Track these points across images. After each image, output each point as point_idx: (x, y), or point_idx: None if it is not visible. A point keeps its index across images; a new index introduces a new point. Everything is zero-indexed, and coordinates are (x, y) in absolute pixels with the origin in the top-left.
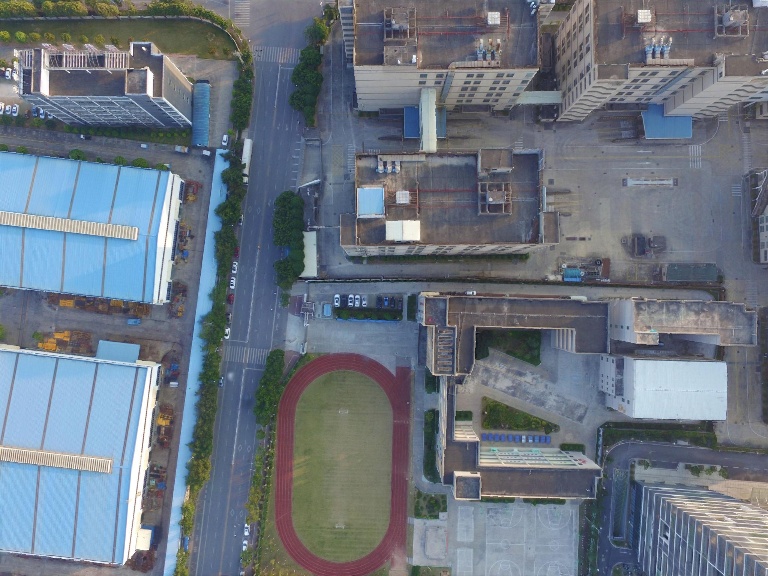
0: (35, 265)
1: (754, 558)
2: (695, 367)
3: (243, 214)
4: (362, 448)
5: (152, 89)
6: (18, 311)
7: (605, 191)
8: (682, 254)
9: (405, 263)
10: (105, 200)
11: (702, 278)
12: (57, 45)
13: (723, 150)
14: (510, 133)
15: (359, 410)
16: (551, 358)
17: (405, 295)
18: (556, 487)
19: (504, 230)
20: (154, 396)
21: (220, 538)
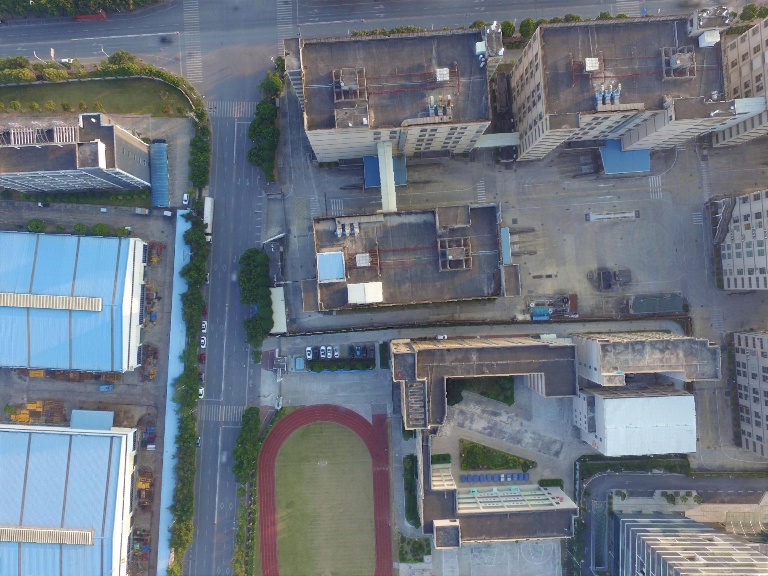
0: None
1: None
2: (663, 402)
3: (209, 272)
4: (343, 497)
5: (105, 160)
6: None
7: (569, 227)
8: (647, 285)
9: (375, 311)
10: (66, 272)
11: (668, 309)
12: (7, 112)
13: (682, 179)
14: (471, 175)
15: (338, 460)
16: (525, 396)
17: (377, 343)
18: (534, 528)
19: (466, 284)
20: (131, 462)
21: None
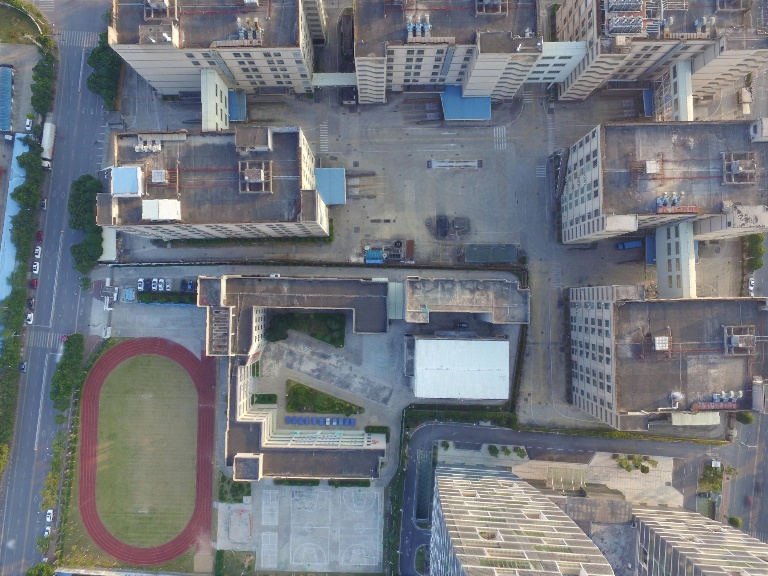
0: None
1: (451, 529)
2: (477, 346)
3: (47, 199)
4: (167, 432)
5: None
6: None
7: (410, 173)
8: (486, 235)
9: (209, 246)
10: None
11: (501, 259)
12: None
13: (527, 131)
14: (315, 116)
15: (164, 394)
16: (356, 340)
17: None
18: (341, 468)
19: (267, 209)
20: None
21: (23, 524)
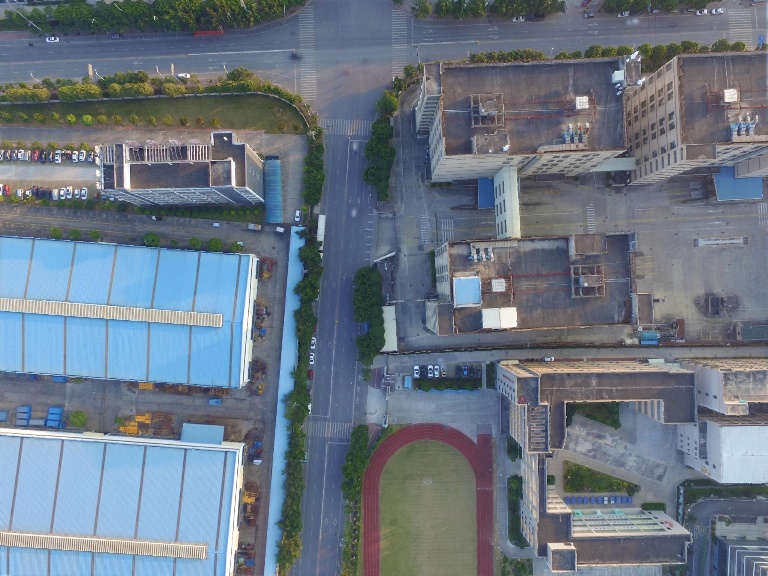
0: (120, 355)
1: None
2: None
3: (319, 289)
4: (447, 516)
5: (235, 178)
6: (97, 396)
7: (677, 252)
8: (754, 312)
9: None
10: (187, 287)
11: None
12: (123, 125)
13: None
14: (581, 198)
15: (442, 479)
16: (630, 420)
17: (483, 363)
18: (647, 553)
19: (597, 311)
20: (241, 477)
21: None
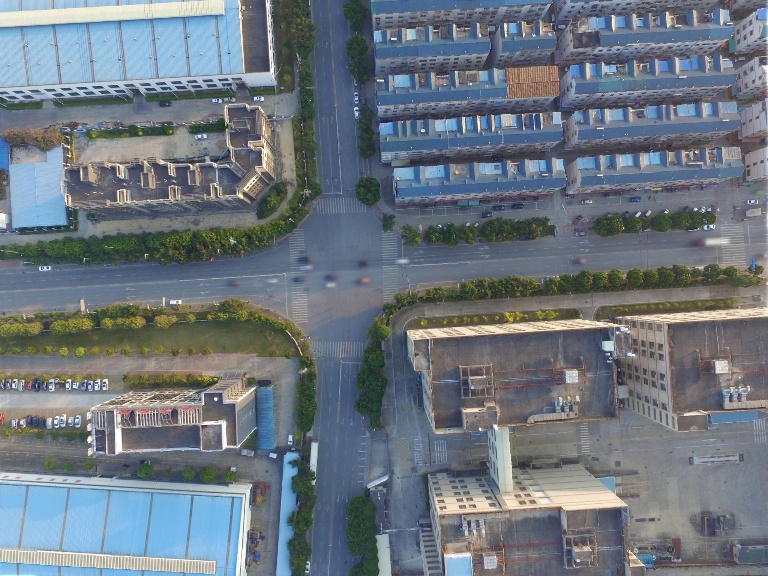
0: None
1: None
2: None
3: None
4: None
5: (226, 437)
6: None
7: (672, 470)
8: (751, 529)
9: None
10: (180, 533)
11: None
12: (115, 352)
13: None
14: None
15: None
16: None
17: None
18: None
19: None
20: None
21: None
